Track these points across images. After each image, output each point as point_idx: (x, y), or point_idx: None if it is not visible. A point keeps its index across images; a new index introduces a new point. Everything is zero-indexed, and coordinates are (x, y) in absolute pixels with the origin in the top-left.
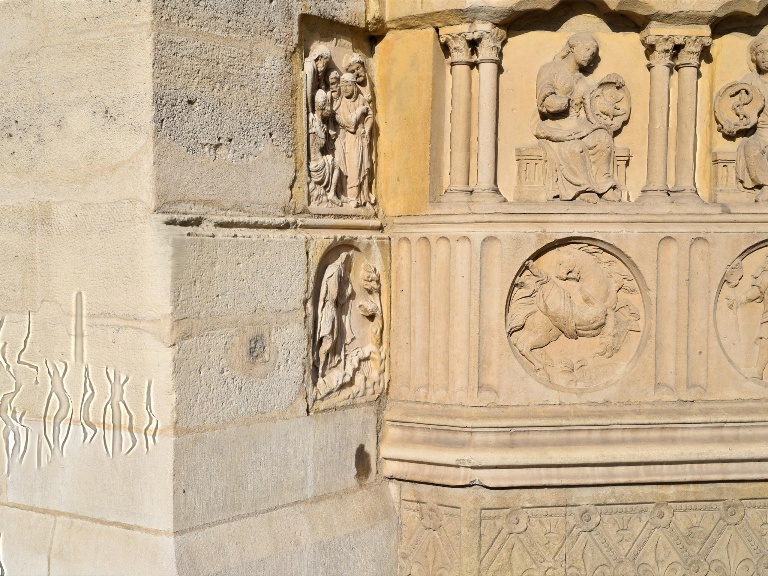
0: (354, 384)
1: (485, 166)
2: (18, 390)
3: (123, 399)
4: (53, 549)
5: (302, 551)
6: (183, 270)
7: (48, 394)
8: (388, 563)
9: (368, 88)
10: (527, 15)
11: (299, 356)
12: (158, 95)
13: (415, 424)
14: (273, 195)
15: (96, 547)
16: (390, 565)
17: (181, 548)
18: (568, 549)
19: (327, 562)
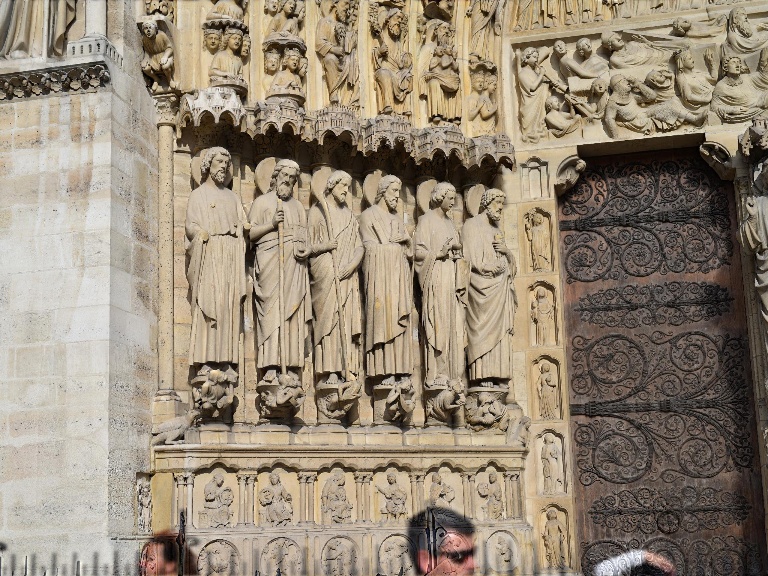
0: None
1: (190, 517)
2: None
3: None
4: None
5: None
6: None
7: None
8: None
9: None
10: (202, 469)
11: None
12: (109, 502)
13: None
14: None
15: None
16: None
17: None
18: None
19: None
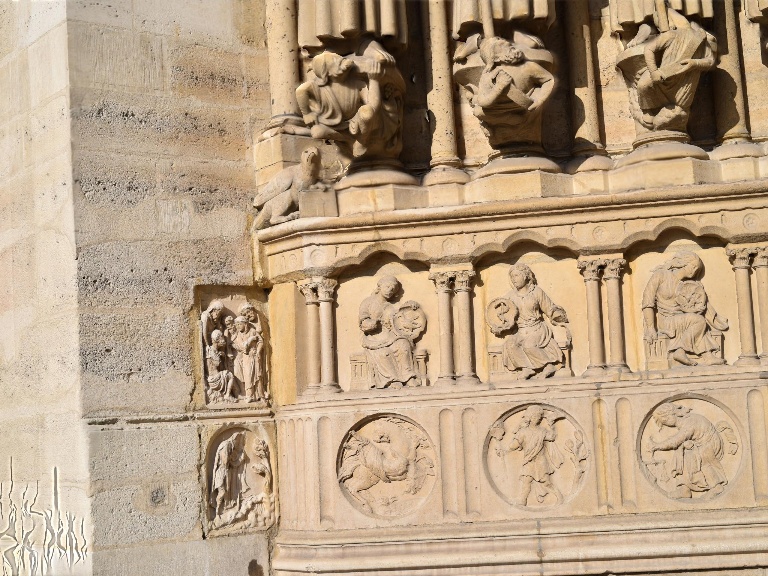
0: (247, 519)
1: (325, 370)
2: (33, 529)
3: (73, 530)
4: None
5: None
6: (97, 451)
7: (45, 530)
8: None
9: (259, 323)
10: (349, 268)
11: (195, 501)
12: (84, 349)
13: (290, 545)
14: (176, 400)
15: None
16: None
17: None
18: None
19: None
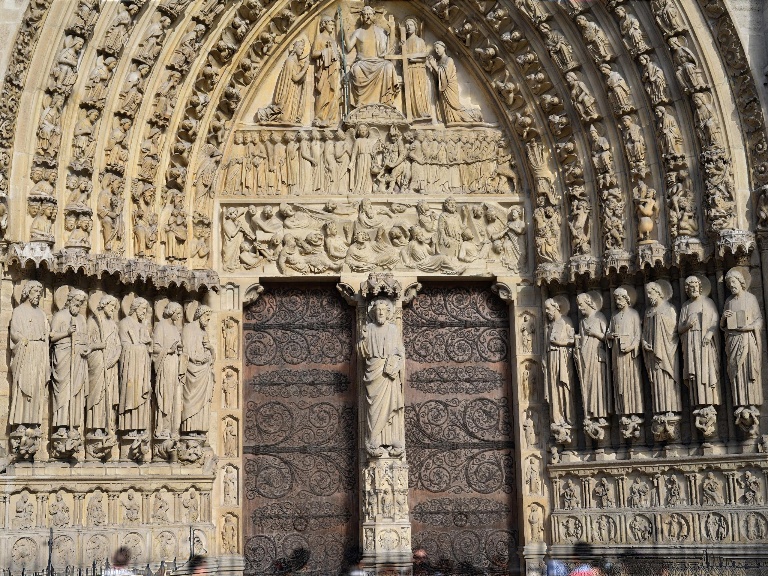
0: None
1: (7, 523)
2: None
3: None
4: None
5: None
6: None
7: None
8: None
9: None
10: None
11: None
12: None
13: None
14: None
15: None
16: None
17: None
18: None
19: None
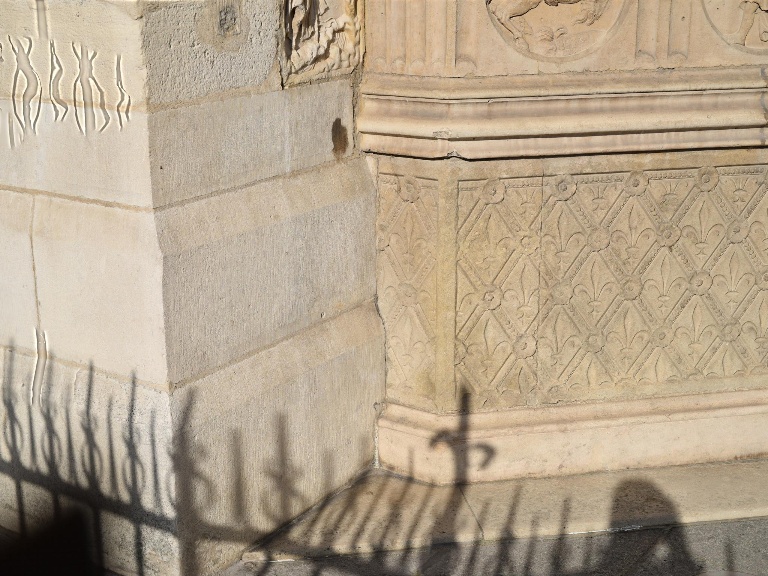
0: (329, 57)
1: None
2: None
3: (92, 75)
4: (34, 227)
5: (282, 225)
6: None
7: (14, 72)
8: (367, 235)
9: None
10: None
11: (271, 28)
12: None
13: (392, 97)
14: None
15: (77, 224)
16: (369, 237)
17: (162, 224)
18: (544, 218)
19: (307, 235)
